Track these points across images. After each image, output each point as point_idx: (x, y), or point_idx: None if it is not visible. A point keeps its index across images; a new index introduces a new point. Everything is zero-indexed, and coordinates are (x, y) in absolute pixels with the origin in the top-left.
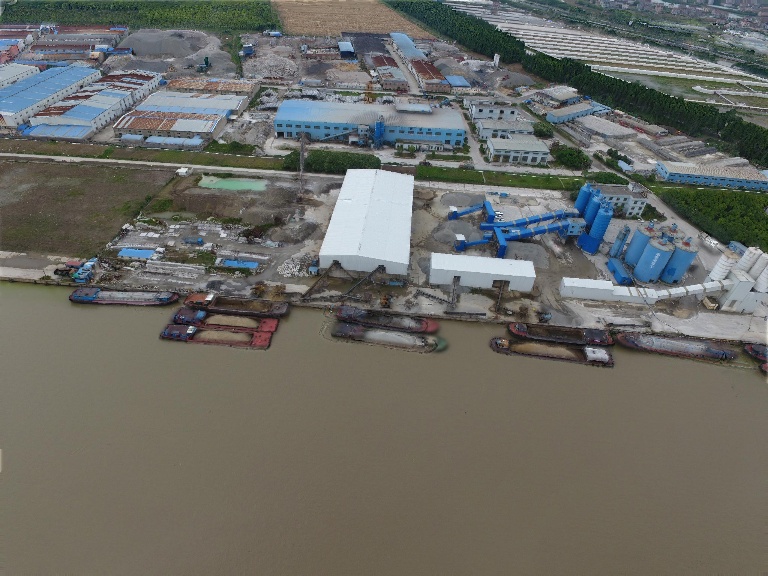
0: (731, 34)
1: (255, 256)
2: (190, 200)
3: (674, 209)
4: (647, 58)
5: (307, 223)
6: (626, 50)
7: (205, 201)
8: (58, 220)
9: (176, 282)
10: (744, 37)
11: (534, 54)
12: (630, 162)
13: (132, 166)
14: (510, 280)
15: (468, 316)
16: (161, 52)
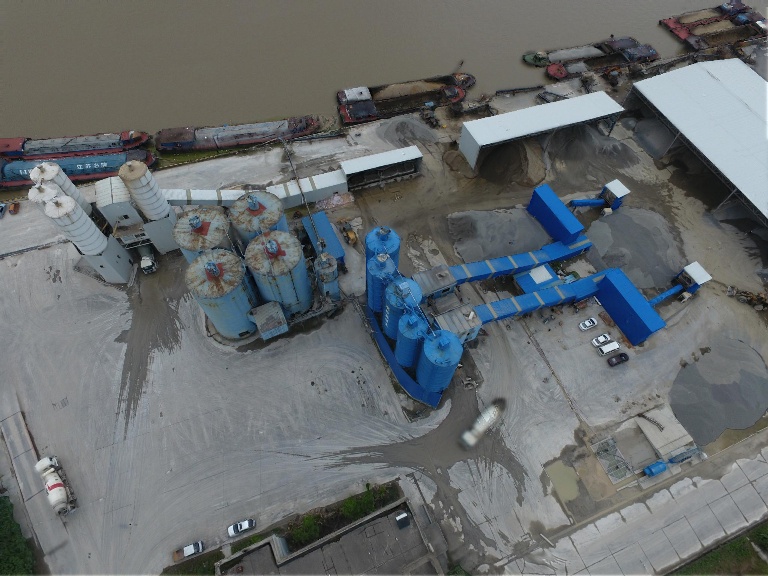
0: None
1: None
2: None
3: None
4: None
5: None
6: None
7: None
8: None
9: None
10: None
11: None
12: None
13: None
14: None
15: None
16: None
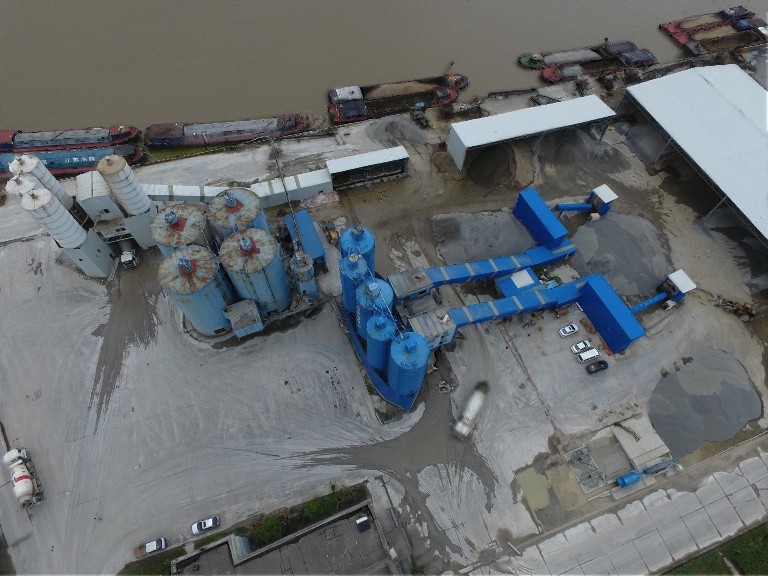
0: None
1: None
2: None
3: None
4: None
5: None
6: None
7: None
8: None
9: None
10: None
11: None
12: None
13: None
14: None
15: None
16: None
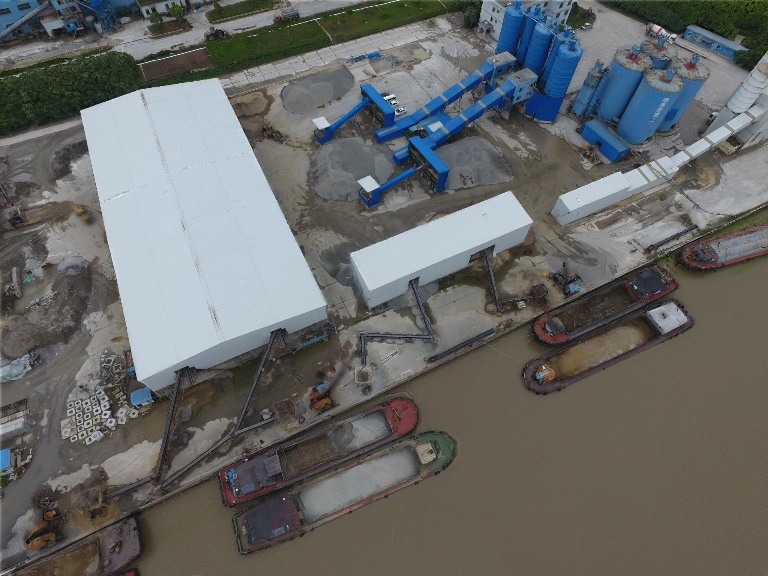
0: None
1: None
2: None
3: None
4: None
5: (64, 278)
6: None
7: None
8: None
9: None
10: None
11: None
12: None
13: None
14: (495, 243)
15: (467, 347)
16: None
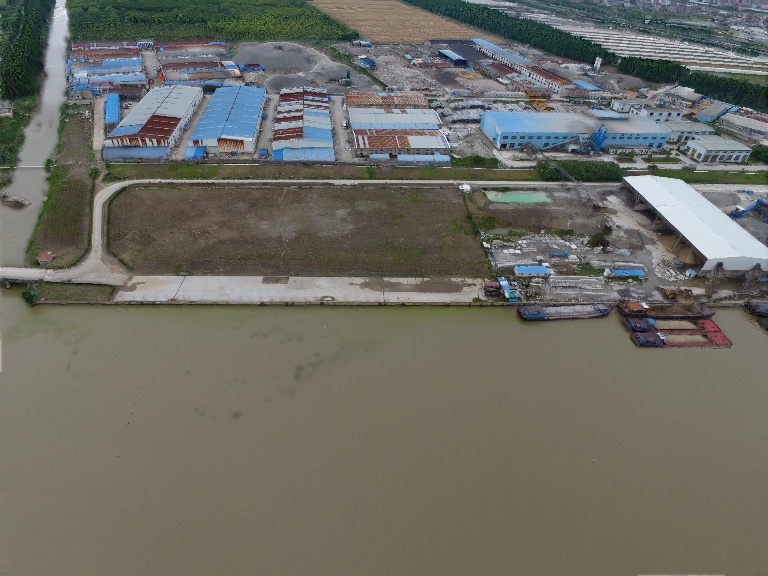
0: (734, 30)
1: (632, 264)
2: (514, 215)
3: None
4: (700, 56)
5: (635, 230)
6: (675, 49)
7: (529, 215)
8: (416, 243)
9: (591, 294)
10: (749, 32)
11: None
12: None
13: (410, 185)
14: None
15: None
16: (286, 66)
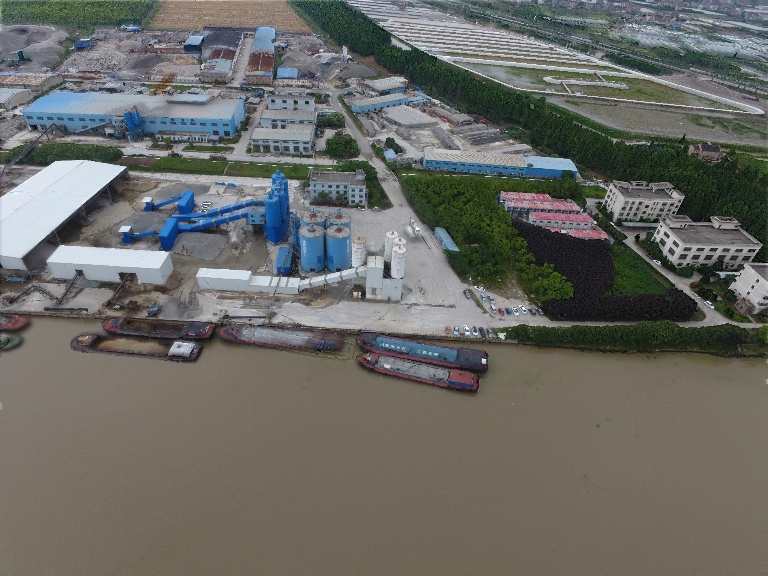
0: (633, 28)
1: None
2: None
3: (406, 196)
4: (522, 50)
5: None
6: (506, 43)
7: None
8: None
9: None
10: (643, 30)
11: (405, 47)
12: (402, 150)
13: None
14: (135, 272)
15: (69, 312)
16: None
